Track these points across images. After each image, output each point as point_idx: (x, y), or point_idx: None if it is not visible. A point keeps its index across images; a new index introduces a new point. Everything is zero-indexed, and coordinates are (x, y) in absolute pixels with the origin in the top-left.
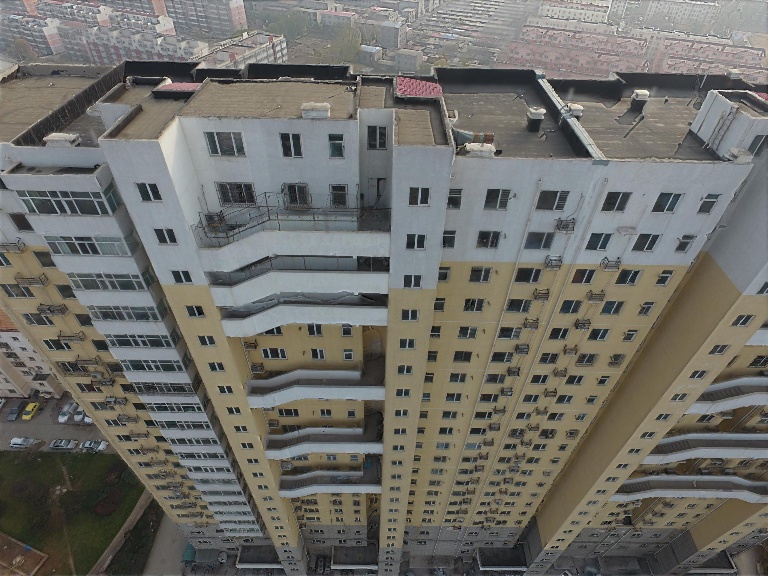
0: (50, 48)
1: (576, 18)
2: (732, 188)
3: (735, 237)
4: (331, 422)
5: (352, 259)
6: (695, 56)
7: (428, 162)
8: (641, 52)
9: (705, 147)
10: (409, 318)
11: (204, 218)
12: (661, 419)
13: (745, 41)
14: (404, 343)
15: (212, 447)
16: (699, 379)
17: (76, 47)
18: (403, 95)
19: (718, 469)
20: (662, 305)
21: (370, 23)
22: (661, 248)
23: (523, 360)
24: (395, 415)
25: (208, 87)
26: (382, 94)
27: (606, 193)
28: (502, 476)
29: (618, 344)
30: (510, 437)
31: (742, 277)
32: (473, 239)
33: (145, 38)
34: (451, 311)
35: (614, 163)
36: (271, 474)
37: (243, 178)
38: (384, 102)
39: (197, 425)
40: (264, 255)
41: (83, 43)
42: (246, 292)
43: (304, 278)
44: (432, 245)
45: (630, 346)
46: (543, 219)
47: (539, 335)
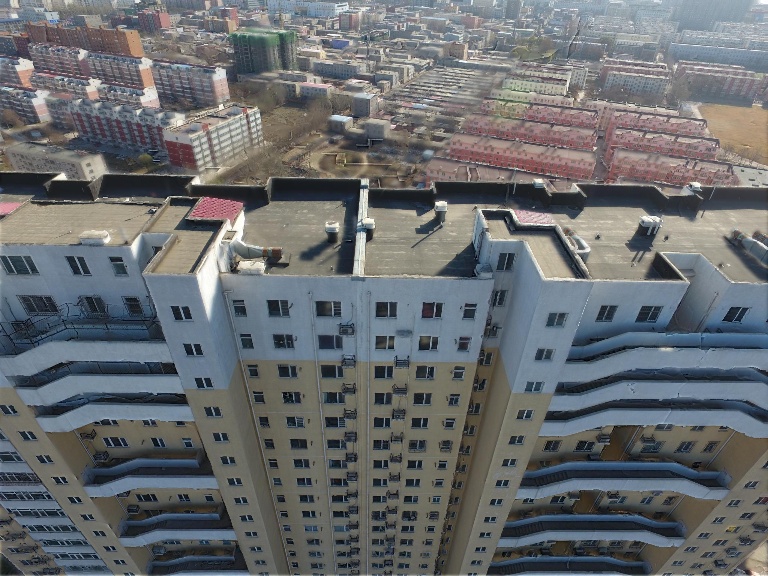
0: (38, 117)
1: (537, 90)
2: (484, 299)
3: (508, 338)
4: (191, 507)
5: (141, 364)
6: (643, 126)
7: (178, 287)
8: (593, 122)
9: (475, 258)
10: (214, 414)
11: (10, 326)
12: (496, 504)
13: (691, 112)
14: (218, 436)
15: (72, 534)
16: (513, 467)
17: (62, 116)
18: (193, 218)
19: (592, 549)
20: (467, 397)
21: (345, 94)
22: (443, 348)
23: (357, 447)
24: (236, 502)
25: (24, 209)
26: (183, 214)
27: (374, 303)
28: (382, 558)
29: (441, 431)
30: (373, 520)
31: (511, 376)
32: (269, 341)
33: (126, 109)
34: (272, 403)
35: (370, 279)
36: (133, 561)
37: (42, 292)
38: (178, 223)
39: (51, 512)
40: (57, 362)
41: (69, 113)
42: (51, 393)
43: (101, 381)
44: (208, 353)
45: (454, 433)
46: (326, 324)
47: (363, 424)
